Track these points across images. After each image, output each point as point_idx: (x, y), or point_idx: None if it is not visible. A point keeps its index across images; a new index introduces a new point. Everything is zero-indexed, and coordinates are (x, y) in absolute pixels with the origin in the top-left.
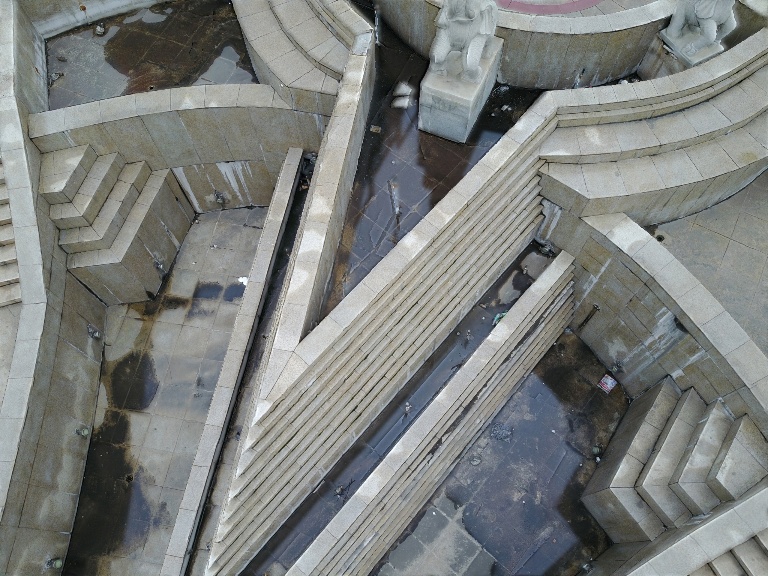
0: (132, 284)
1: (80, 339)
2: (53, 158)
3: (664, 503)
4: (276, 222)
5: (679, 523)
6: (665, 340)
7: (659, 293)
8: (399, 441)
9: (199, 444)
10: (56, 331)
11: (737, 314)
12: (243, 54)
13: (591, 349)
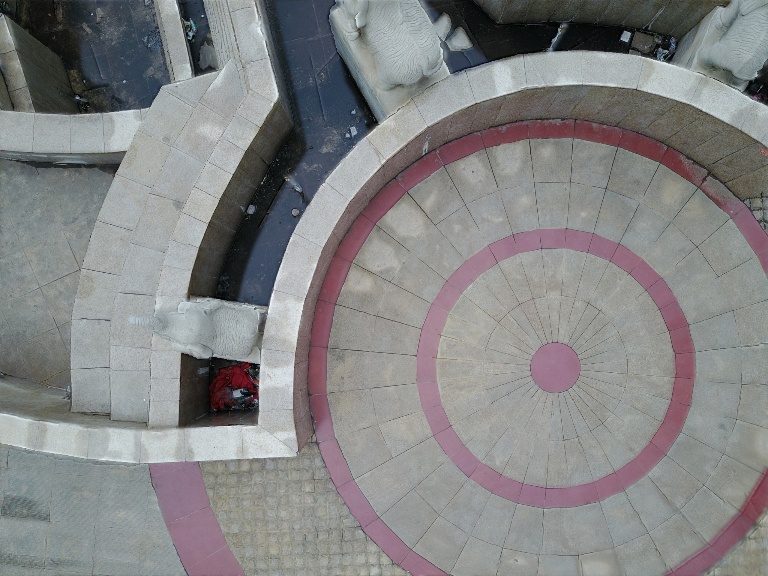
0: None
1: None
2: None
3: None
4: None
5: None
6: None
7: None
8: None
9: None
10: None
11: (14, 201)
12: None
13: None
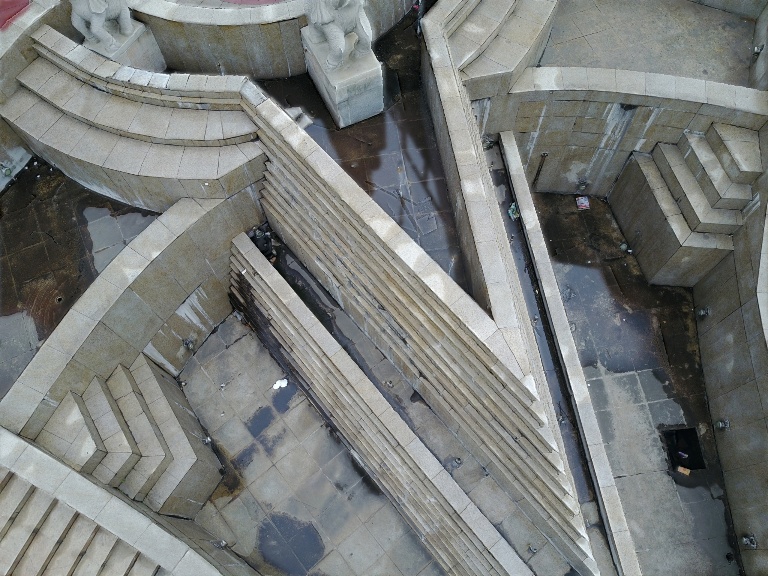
0: (208, 474)
1: (224, 557)
2: (51, 433)
3: (721, 220)
4: (294, 299)
5: (740, 222)
6: (618, 129)
7: (599, 98)
8: (559, 345)
9: (445, 497)
10: (216, 563)
11: None
12: (107, 204)
13: (551, 192)
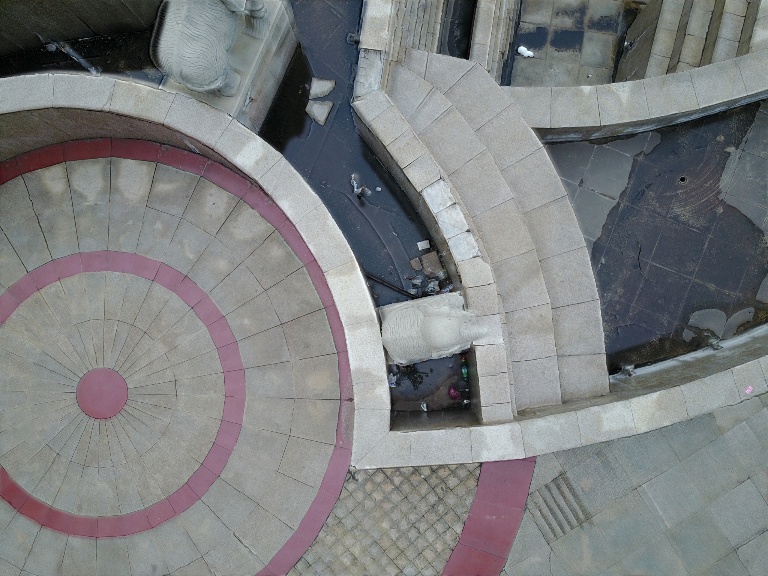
0: None
1: None
2: None
3: None
4: None
5: None
6: None
7: None
8: None
9: None
10: None
11: None
12: None
13: None
